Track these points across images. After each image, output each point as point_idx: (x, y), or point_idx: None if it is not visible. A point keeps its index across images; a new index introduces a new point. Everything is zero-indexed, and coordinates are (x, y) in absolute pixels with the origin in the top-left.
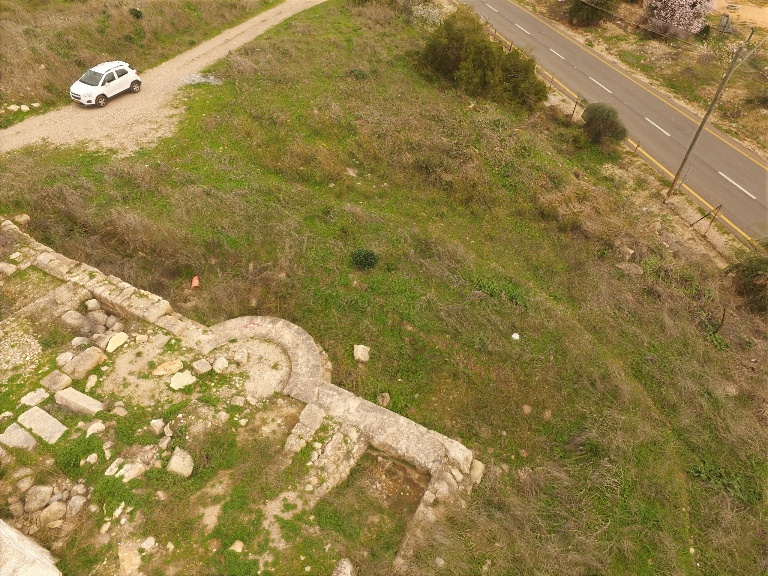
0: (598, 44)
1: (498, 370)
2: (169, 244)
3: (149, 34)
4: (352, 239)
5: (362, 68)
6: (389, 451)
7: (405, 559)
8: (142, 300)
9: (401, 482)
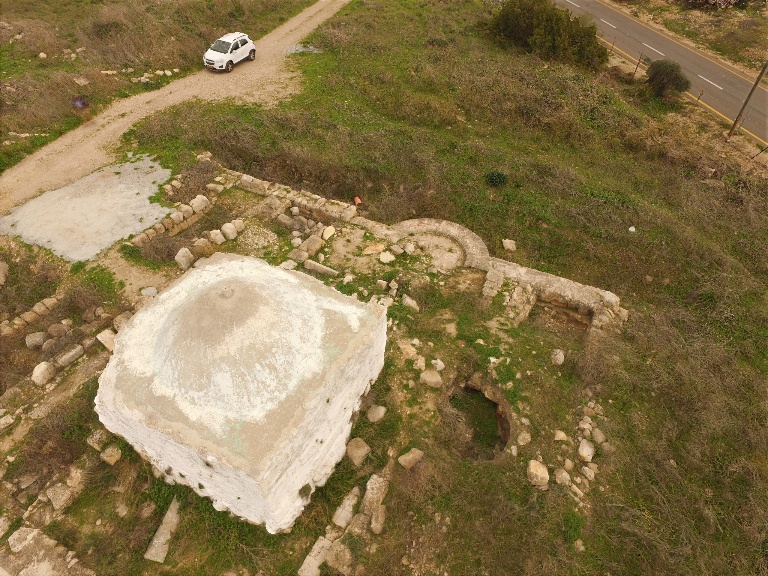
0: (643, 15)
1: (622, 252)
2: (333, 171)
3: (248, 11)
4: (480, 166)
5: (441, 37)
6: (557, 300)
7: None
8: (334, 206)
9: (566, 323)
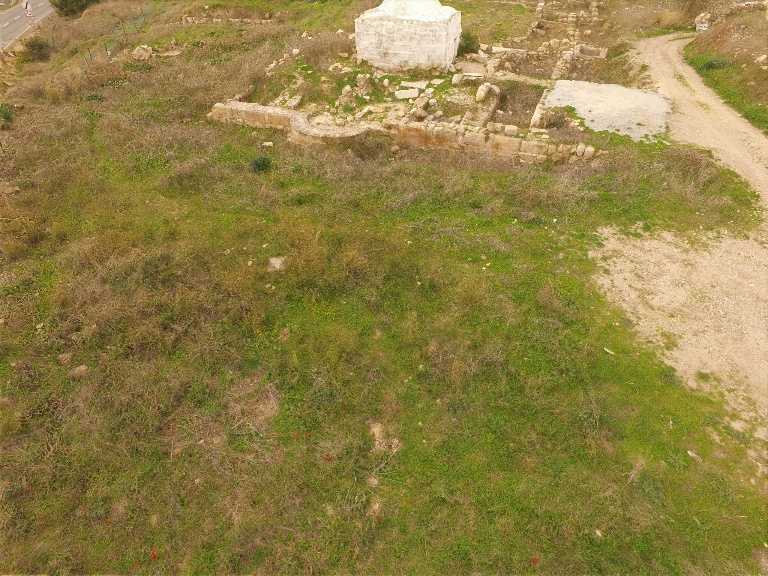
0: None
1: None
2: None
3: None
4: None
5: None
6: None
7: None
8: None
9: None
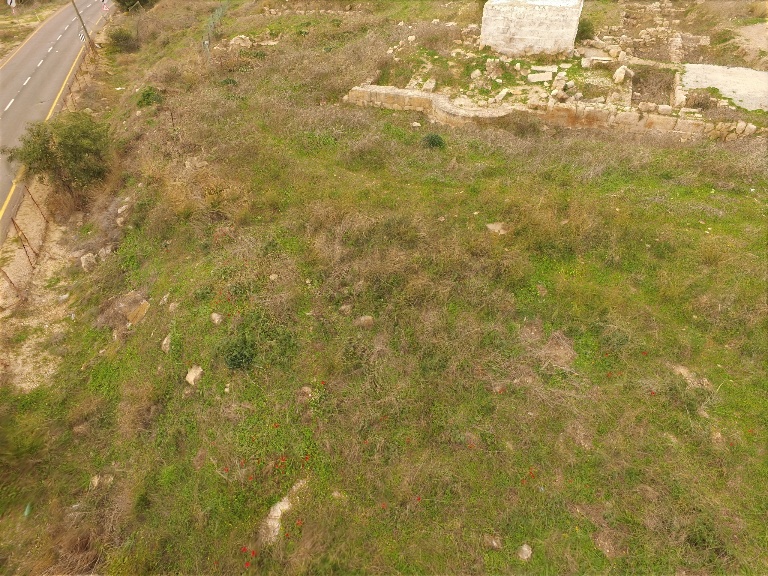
0: None
1: None
2: None
3: None
4: None
5: None
6: None
7: None
8: (567, 105)
9: None
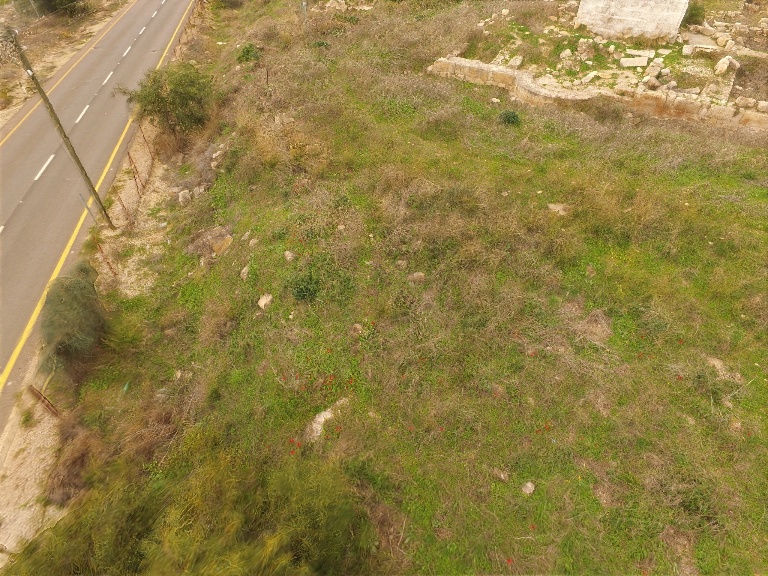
0: None
1: None
2: None
3: None
4: None
5: None
6: None
7: (465, 44)
8: (657, 93)
9: None
